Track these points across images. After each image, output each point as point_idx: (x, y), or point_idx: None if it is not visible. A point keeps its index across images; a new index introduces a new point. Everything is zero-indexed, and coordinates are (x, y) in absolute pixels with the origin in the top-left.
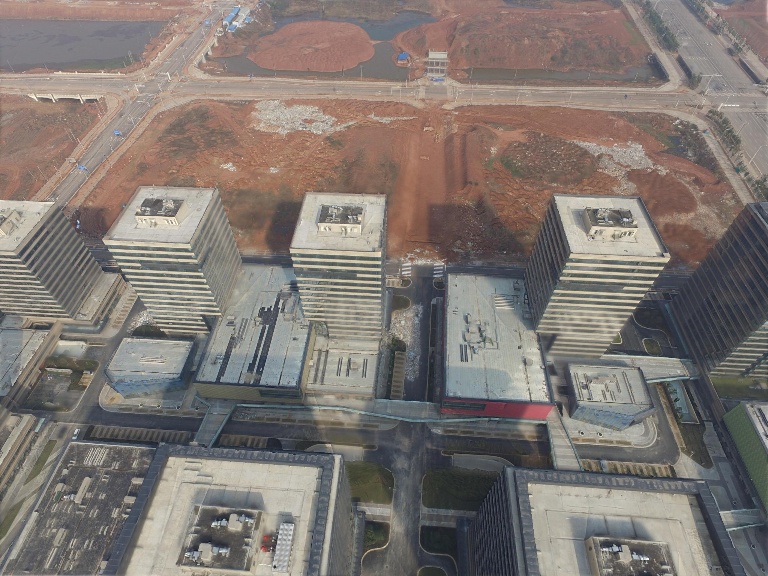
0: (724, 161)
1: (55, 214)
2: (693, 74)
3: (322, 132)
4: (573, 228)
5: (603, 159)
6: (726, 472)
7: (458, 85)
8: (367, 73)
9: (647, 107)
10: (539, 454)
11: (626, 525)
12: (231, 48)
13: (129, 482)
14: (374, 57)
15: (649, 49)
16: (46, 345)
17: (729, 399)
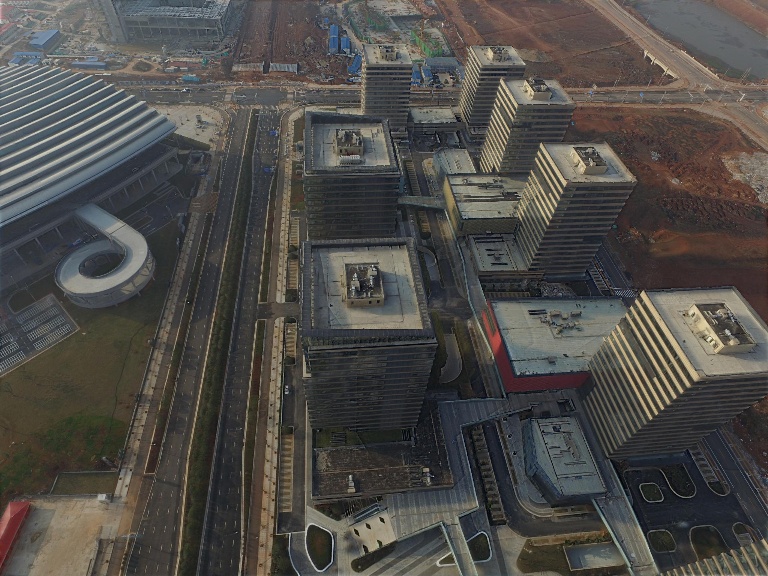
0: None
1: (519, 70)
2: None
3: (766, 203)
4: (688, 300)
5: None
6: None
7: None
8: None
9: None
10: None
11: (393, 292)
12: None
13: None
14: None
15: None
16: (449, 126)
17: None
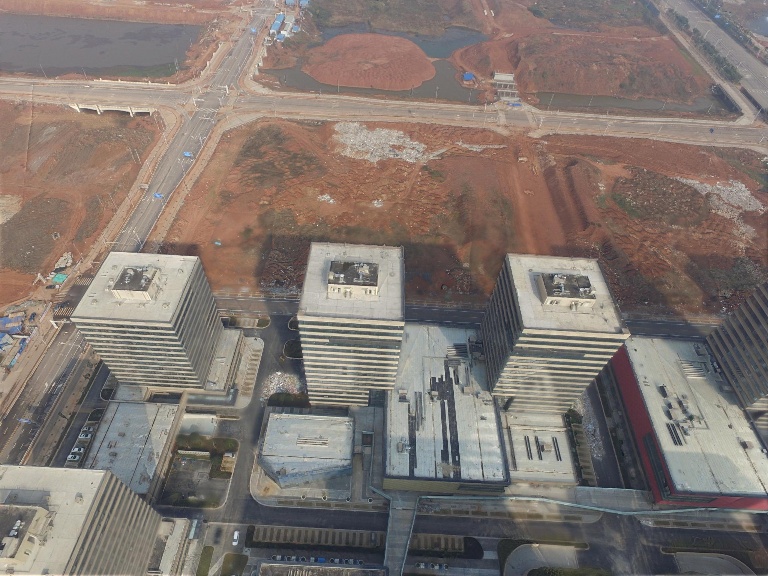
0: None
1: (198, 270)
2: (767, 109)
3: (416, 160)
4: None
5: (712, 199)
6: None
7: (537, 111)
8: (438, 94)
9: (732, 142)
10: (765, 549)
11: None
12: (283, 59)
13: None
14: (436, 76)
15: (712, 80)
16: (176, 422)
17: None
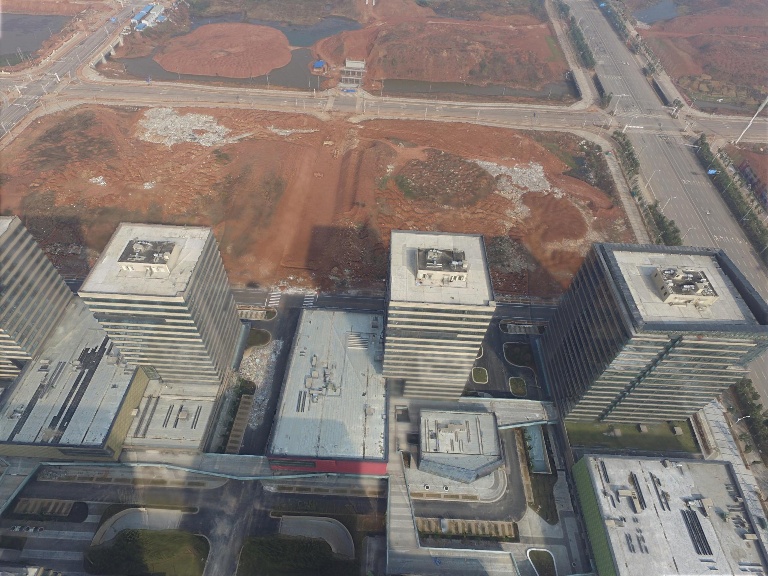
0: (622, 184)
1: None
2: (604, 93)
3: (212, 144)
4: (403, 270)
5: (501, 180)
6: (571, 529)
7: (369, 97)
8: (276, 81)
9: (556, 126)
10: (377, 513)
11: None
12: (137, 48)
13: None
14: (290, 64)
15: (567, 66)
16: None
17: (580, 448)
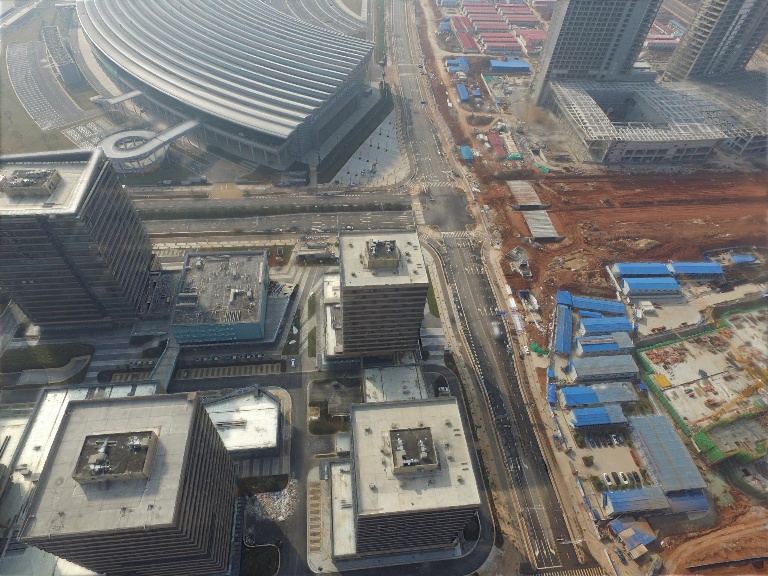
0: None
1: None
2: None
3: None
4: None
5: None
6: None
7: None
8: None
9: None
10: None
11: None
12: None
13: (199, 305)
14: None
15: None
16: None
17: None
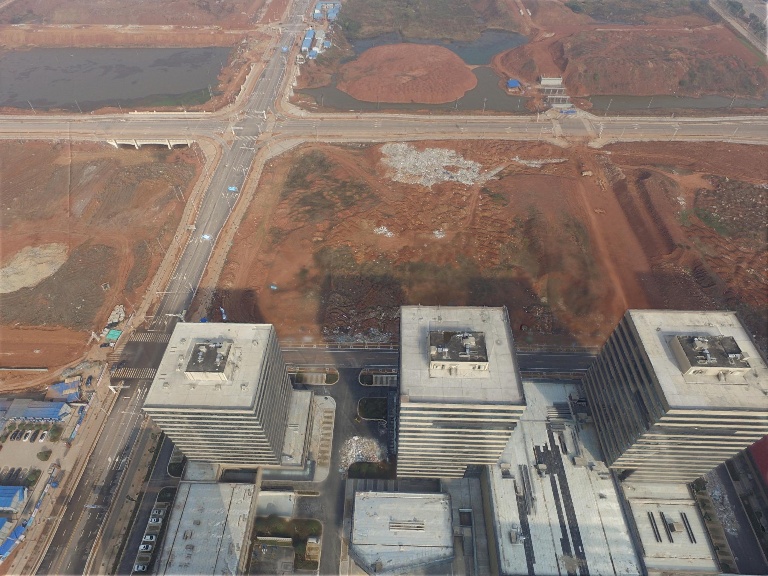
0: None
1: (272, 339)
2: None
3: (473, 182)
4: None
5: None
6: None
7: (594, 118)
8: None
9: None
10: None
11: None
12: (318, 78)
13: None
14: (478, 85)
15: None
16: (254, 505)
17: None
